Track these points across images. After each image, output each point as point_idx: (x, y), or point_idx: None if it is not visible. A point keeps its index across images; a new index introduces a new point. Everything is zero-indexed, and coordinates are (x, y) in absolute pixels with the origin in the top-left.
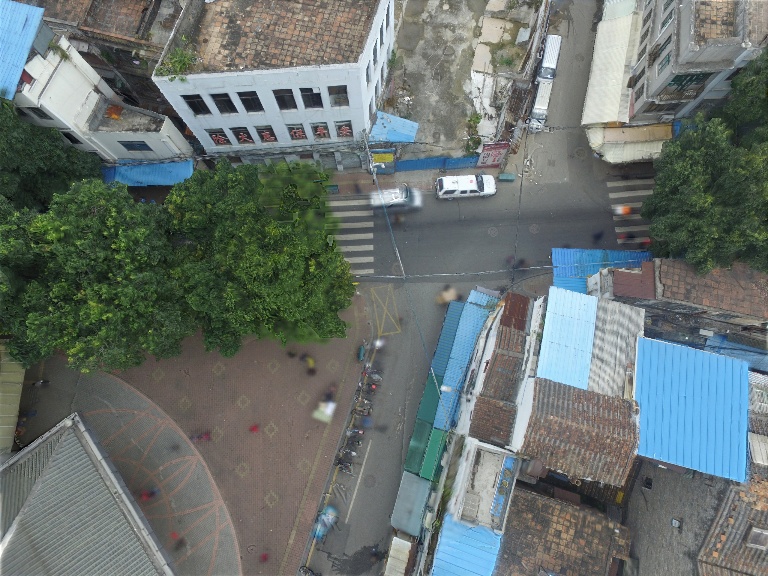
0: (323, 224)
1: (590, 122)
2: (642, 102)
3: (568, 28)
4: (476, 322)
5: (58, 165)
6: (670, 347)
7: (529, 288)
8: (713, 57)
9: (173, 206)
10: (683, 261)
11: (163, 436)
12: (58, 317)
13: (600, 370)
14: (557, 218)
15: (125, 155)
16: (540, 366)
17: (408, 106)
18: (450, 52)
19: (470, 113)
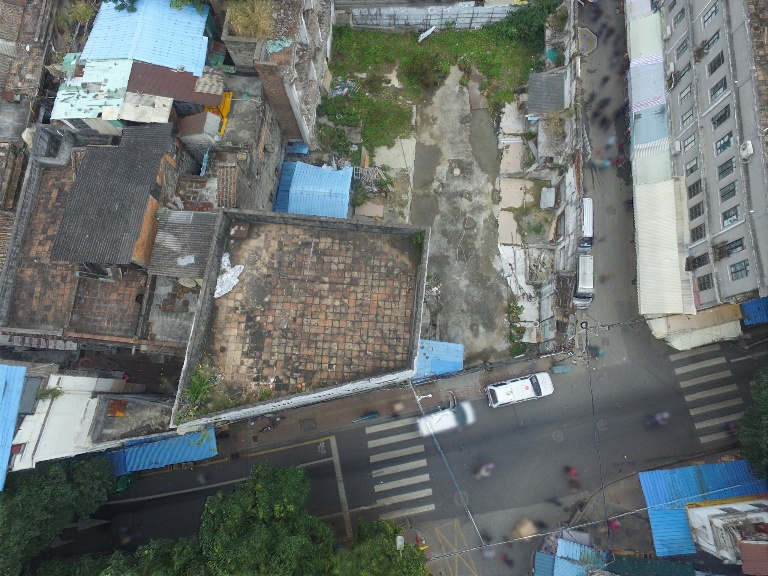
0: (368, 456)
1: (650, 312)
2: (712, 298)
3: (592, 178)
4: None
5: (63, 501)
6: None
7: (610, 499)
8: None
9: None
10: None
11: None
12: None
13: None
14: (624, 408)
15: None
16: None
17: (437, 297)
18: (471, 225)
19: (506, 295)
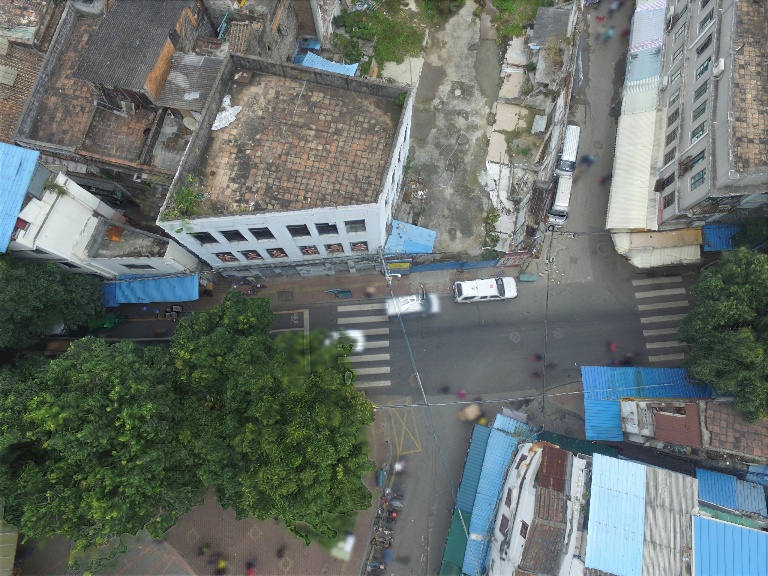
0: (336, 331)
1: (616, 226)
2: (673, 212)
3: (585, 113)
4: (504, 452)
5: (55, 299)
6: (729, 528)
7: (555, 399)
8: (753, 181)
9: (181, 363)
10: (730, 405)
11: (170, 574)
12: (57, 506)
13: (654, 556)
14: (582, 321)
15: (126, 271)
16: (588, 553)
17: (422, 200)
18: (464, 141)
19: (487, 207)
